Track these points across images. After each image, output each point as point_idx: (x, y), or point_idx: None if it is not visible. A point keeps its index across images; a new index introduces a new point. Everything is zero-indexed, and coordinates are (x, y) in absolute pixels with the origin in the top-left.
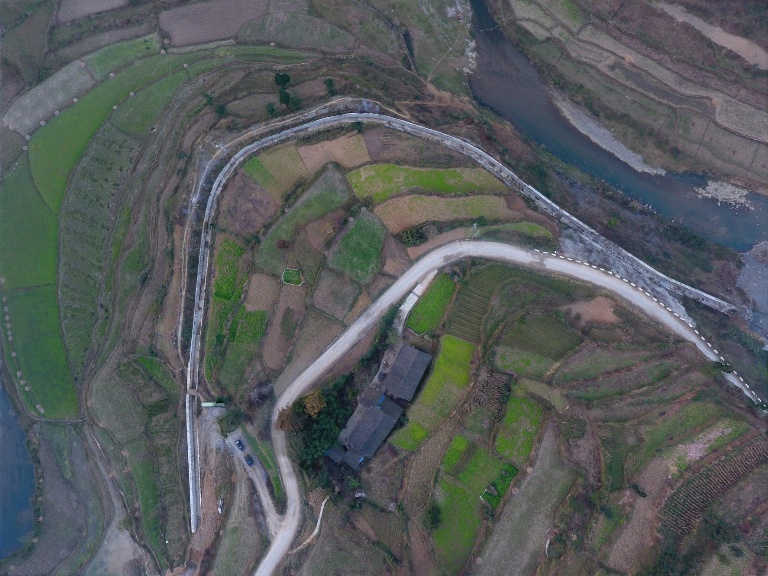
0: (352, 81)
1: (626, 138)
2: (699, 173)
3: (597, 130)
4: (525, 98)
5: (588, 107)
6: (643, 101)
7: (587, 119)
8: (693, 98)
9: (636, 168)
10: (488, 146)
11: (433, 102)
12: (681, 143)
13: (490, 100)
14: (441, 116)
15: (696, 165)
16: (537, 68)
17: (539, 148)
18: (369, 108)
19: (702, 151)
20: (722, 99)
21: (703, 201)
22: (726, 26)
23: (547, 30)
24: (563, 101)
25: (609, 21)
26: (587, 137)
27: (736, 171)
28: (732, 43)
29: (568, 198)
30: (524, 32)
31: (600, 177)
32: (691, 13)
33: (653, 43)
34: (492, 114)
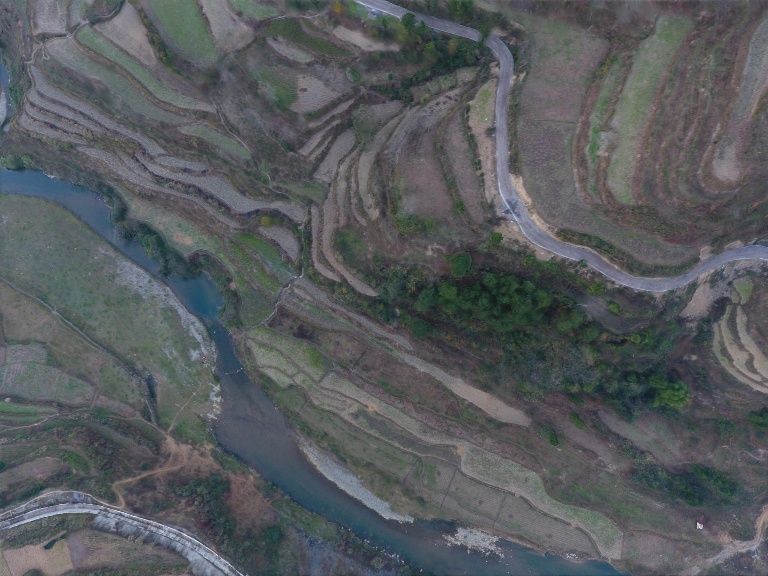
0: (69, 464)
1: (373, 485)
2: (448, 520)
3: (344, 477)
4: (271, 444)
5: (335, 453)
6: (388, 449)
7: (334, 465)
8: (438, 446)
9: (384, 516)
10: (204, 536)
11: (164, 468)
12: (426, 494)
13: (235, 446)
14: (164, 493)
15: (443, 514)
16: (282, 413)
17: (282, 500)
18: (81, 500)
19: (448, 501)
20: (468, 448)
21: (452, 549)
22: (466, 379)
23: (289, 377)
24: (309, 446)
25: (351, 369)
26: (334, 484)
27: (483, 522)
28: (473, 396)
29: (301, 568)
30: (266, 379)
31: (347, 525)
32: (432, 364)
33: (395, 393)
34: (236, 462)
